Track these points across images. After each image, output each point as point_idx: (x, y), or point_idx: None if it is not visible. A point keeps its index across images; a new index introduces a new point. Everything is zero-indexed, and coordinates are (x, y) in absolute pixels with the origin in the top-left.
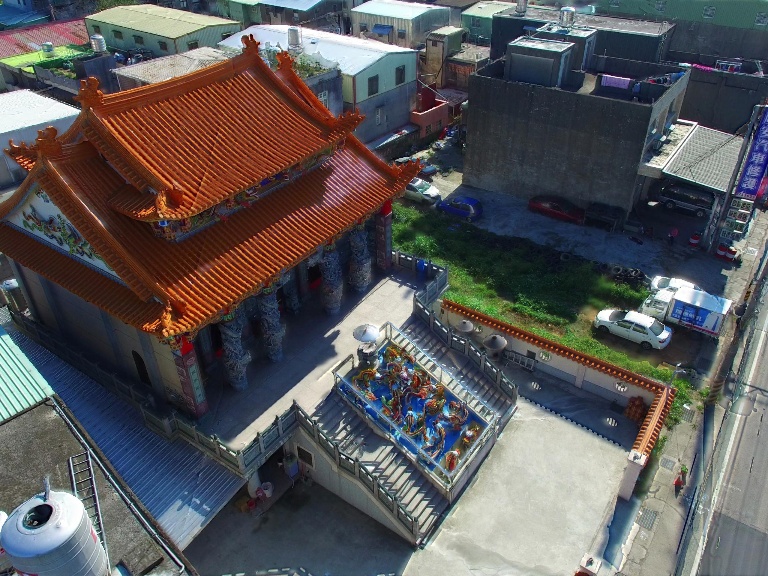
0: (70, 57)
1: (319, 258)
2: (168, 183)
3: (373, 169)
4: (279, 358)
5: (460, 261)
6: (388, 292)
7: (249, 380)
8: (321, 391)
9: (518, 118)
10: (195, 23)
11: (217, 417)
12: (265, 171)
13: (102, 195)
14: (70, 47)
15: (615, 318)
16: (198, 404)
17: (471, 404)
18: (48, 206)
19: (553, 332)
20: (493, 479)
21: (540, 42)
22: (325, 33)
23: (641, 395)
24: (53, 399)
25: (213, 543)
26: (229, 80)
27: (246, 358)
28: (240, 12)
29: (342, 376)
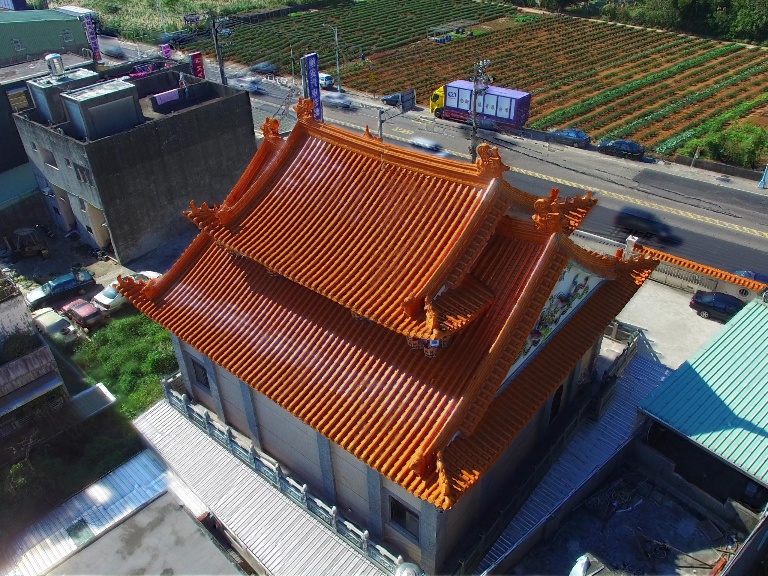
0: None
1: None
2: None
3: None
4: None
5: None
6: None
7: None
8: None
9: (152, 161)
10: None
11: None
12: None
13: None
14: None
15: None
16: None
17: None
18: None
19: None
20: None
21: (90, 90)
22: None
23: None
24: (765, 292)
25: None
26: None
27: None
28: None
29: None
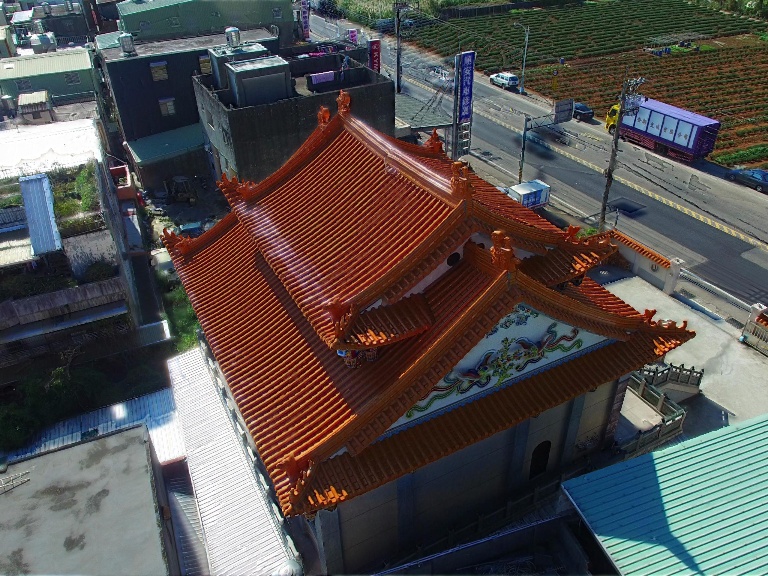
0: None
1: None
2: None
3: None
4: None
5: None
6: None
7: None
8: None
9: (288, 134)
10: None
11: None
12: (509, 198)
13: None
14: None
15: None
16: None
17: None
18: (488, 341)
19: None
20: None
21: (251, 63)
22: None
23: None
24: None
25: None
26: None
27: None
28: None
29: None
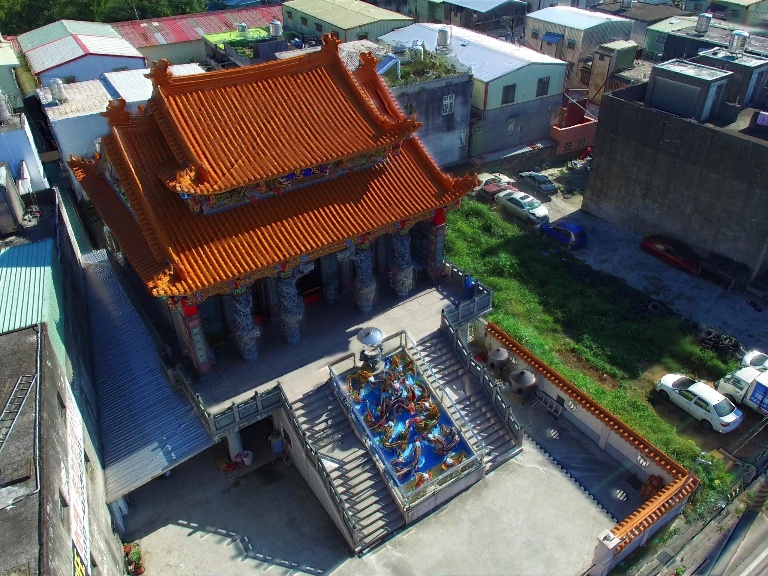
0: (254, 38)
1: (351, 254)
2: (205, 161)
3: (428, 177)
4: (295, 341)
5: (536, 288)
6: (427, 302)
7: (260, 354)
8: (316, 380)
9: (647, 147)
10: (370, 16)
11: (218, 380)
12: (299, 163)
13: (153, 163)
14: (264, 29)
15: (680, 385)
16: (200, 363)
17: (468, 433)
18: None
19: (605, 383)
20: (461, 514)
21: (693, 67)
22: (483, 36)
23: (662, 475)
24: (40, 326)
25: (185, 490)
26: (302, 74)
27: (254, 333)
28: (425, 9)
29: (342, 371)
